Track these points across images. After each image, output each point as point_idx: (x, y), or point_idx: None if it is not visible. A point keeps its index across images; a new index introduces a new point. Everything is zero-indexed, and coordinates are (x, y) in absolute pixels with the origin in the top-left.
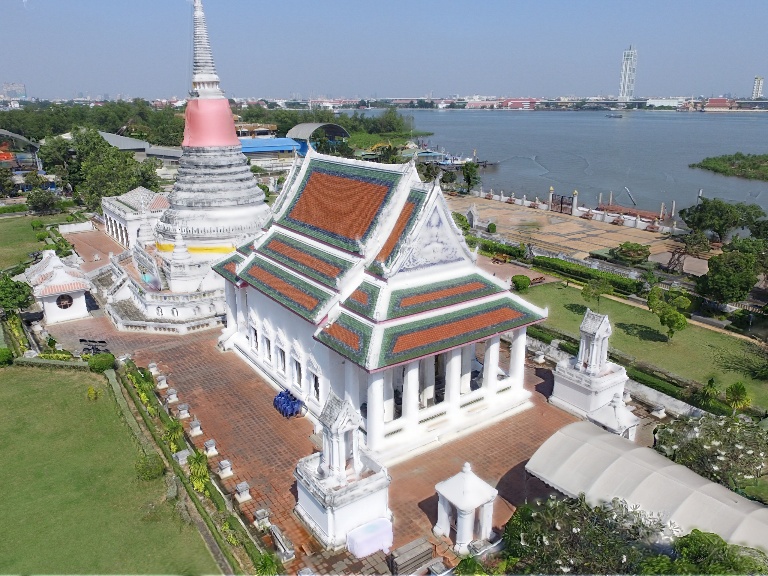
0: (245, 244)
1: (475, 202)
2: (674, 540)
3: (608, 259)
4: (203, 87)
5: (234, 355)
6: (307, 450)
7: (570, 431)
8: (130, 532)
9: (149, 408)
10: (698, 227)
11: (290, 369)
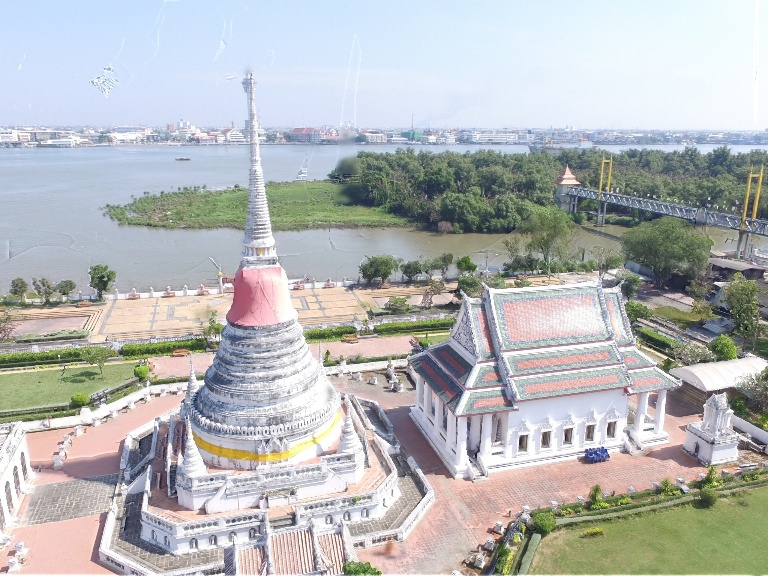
0: (475, 381)
1: (138, 306)
2: (767, 374)
3: (390, 313)
4: (271, 252)
5: (496, 474)
6: (647, 458)
7: (694, 371)
8: (759, 510)
9: (625, 501)
10: (373, 277)
11: (577, 437)
